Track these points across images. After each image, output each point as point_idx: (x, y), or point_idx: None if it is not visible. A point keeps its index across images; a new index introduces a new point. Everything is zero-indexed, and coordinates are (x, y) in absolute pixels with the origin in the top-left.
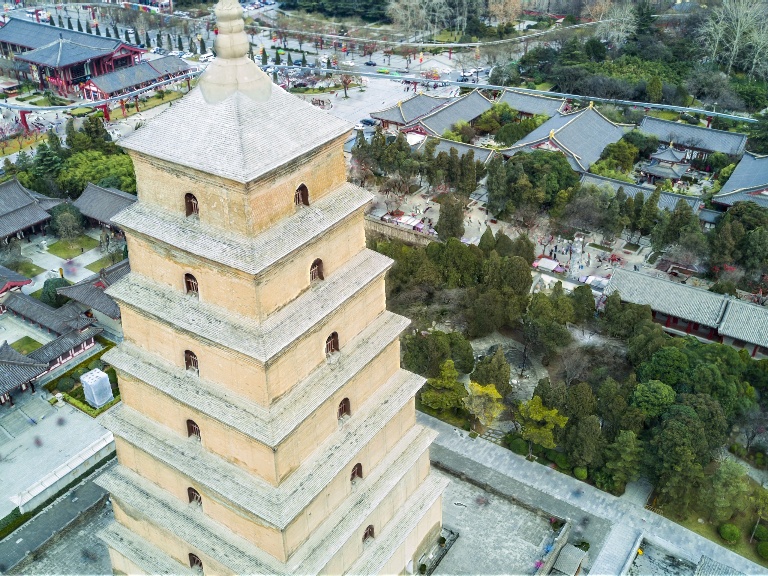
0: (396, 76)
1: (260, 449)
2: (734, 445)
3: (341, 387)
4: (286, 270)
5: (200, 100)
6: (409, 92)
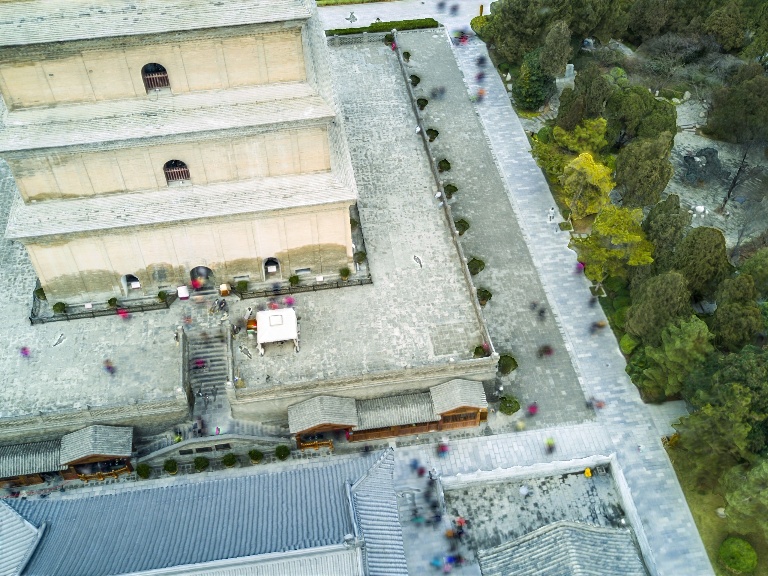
0: None
1: None
2: None
3: None
4: None
5: None
6: None
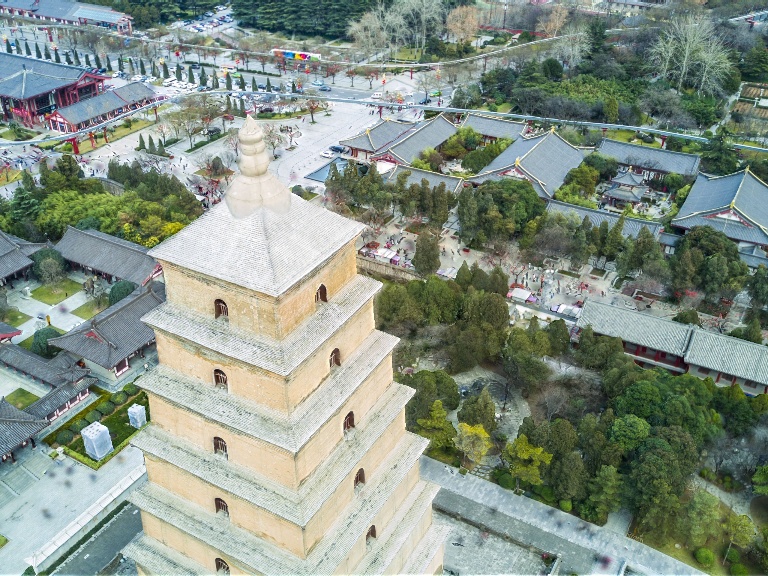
0: (361, 100)
1: (289, 527)
2: (704, 470)
3: None
4: (310, 364)
5: (227, 214)
6: (374, 115)
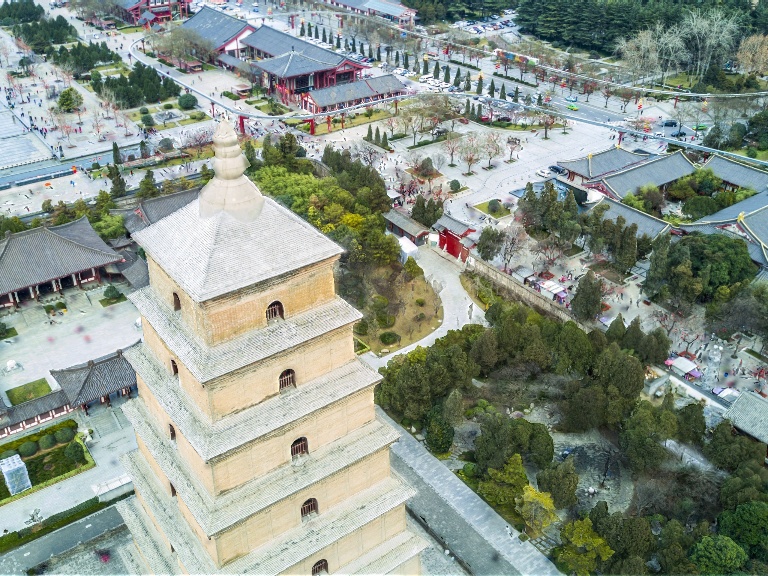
0: (602, 123)
1: None
2: None
3: (304, 489)
4: (247, 378)
5: (197, 212)
6: (614, 140)
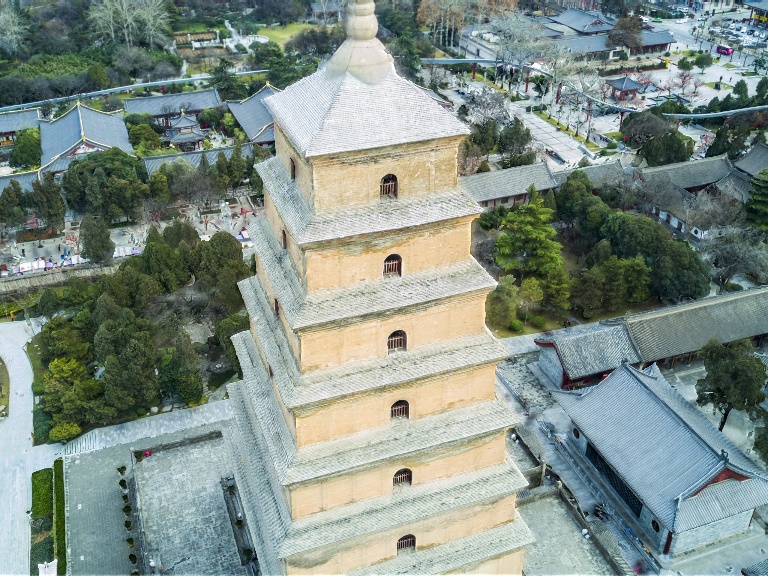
0: None
1: (483, 373)
2: None
3: None
4: None
5: (360, 85)
6: None
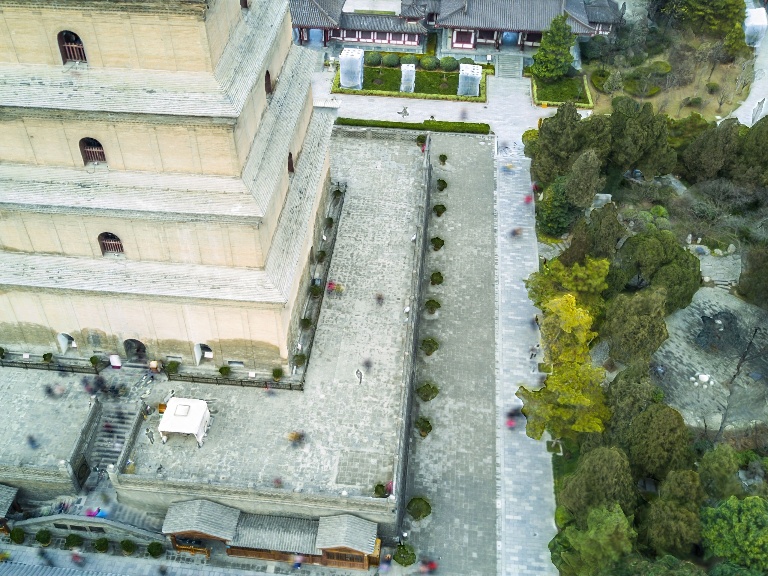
0: None
1: None
2: None
3: (51, 4)
4: None
5: None
6: None
